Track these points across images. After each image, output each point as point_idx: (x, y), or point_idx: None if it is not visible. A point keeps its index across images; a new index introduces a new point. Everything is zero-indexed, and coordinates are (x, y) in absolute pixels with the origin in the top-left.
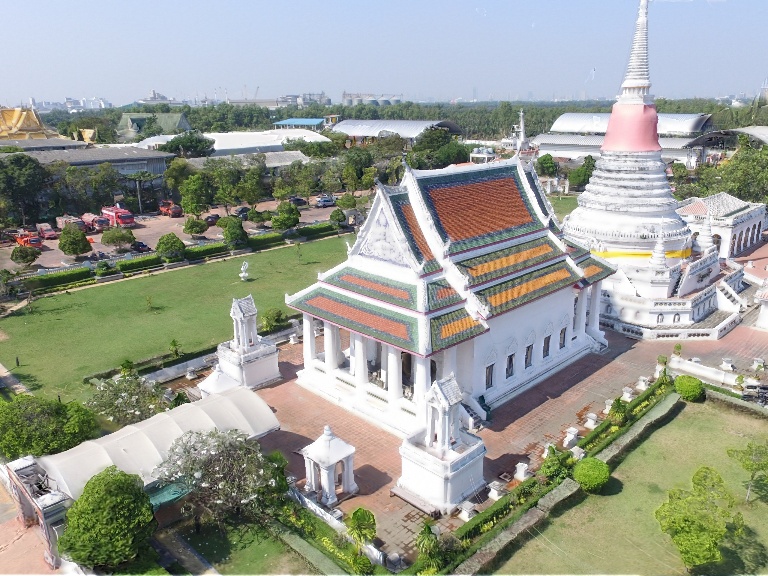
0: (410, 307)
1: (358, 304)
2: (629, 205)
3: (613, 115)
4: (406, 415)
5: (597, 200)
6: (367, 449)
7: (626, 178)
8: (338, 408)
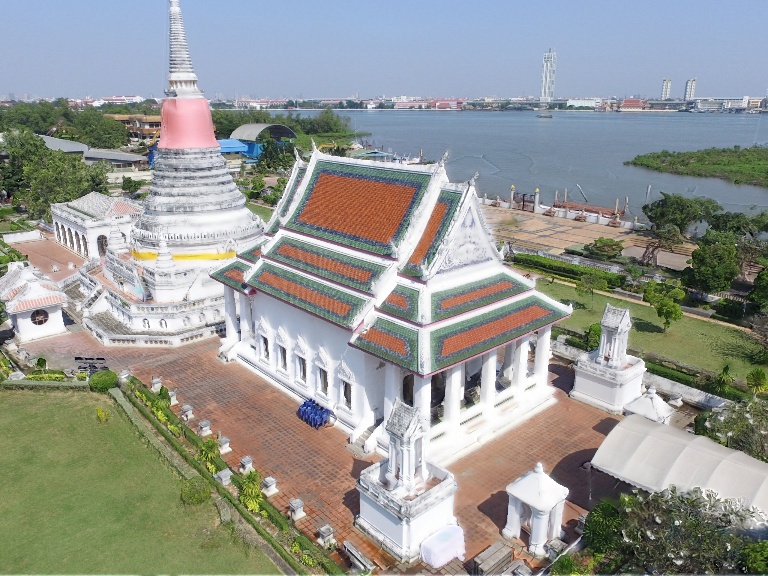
0: (525, 289)
1: (484, 319)
2: (235, 199)
3: (179, 110)
4: (530, 392)
5: (206, 201)
6: (568, 428)
7: (220, 174)
8: (489, 446)
